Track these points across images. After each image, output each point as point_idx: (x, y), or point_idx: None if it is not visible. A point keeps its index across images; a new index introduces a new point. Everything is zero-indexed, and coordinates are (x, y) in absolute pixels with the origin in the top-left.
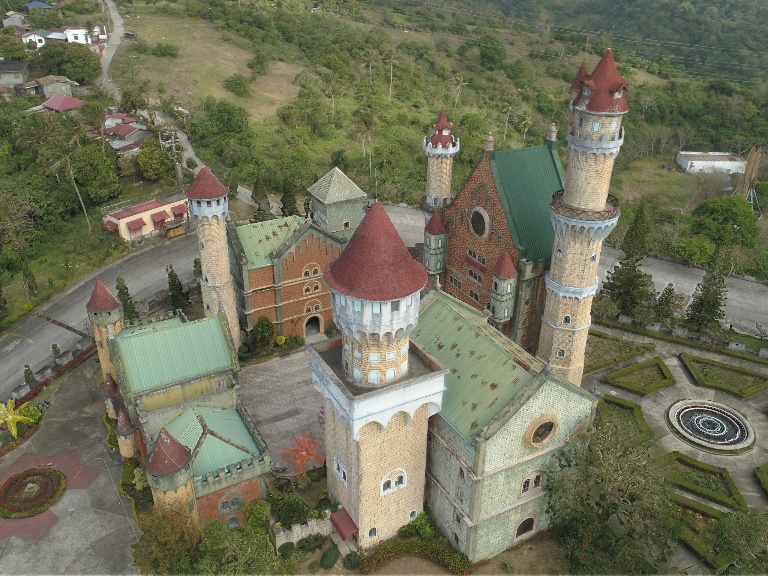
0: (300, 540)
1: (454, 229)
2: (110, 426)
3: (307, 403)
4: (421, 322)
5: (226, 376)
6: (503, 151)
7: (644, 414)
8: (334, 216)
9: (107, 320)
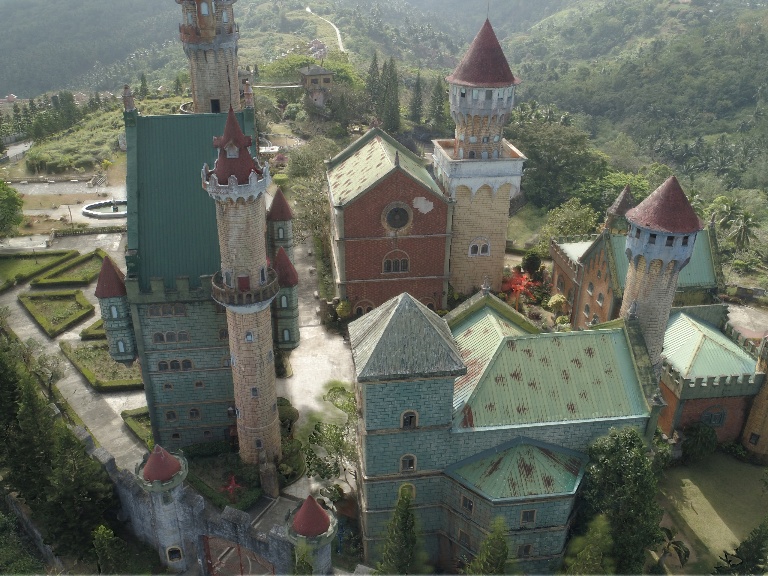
0: None
1: None
2: None
3: None
4: None
5: None
6: (224, 113)
7: None
8: None
9: None
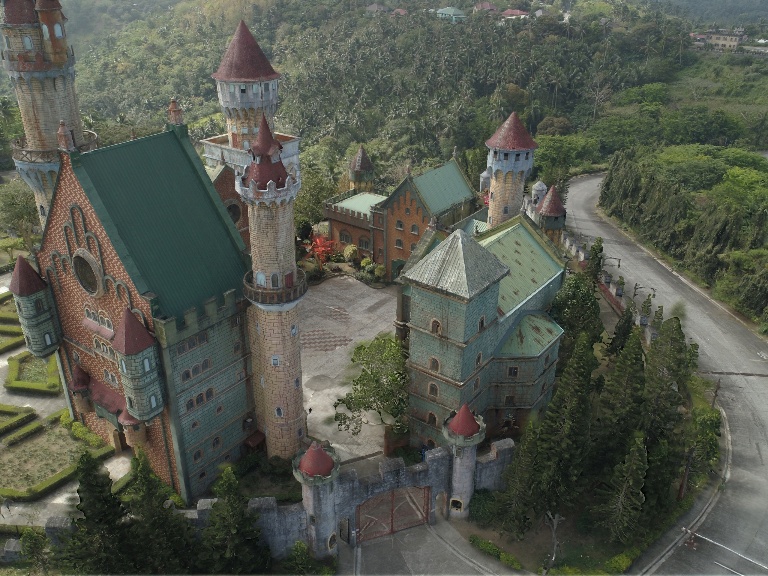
0: None
1: None
2: None
3: (367, 318)
4: None
5: None
6: (155, 135)
7: (2, 389)
8: None
9: None
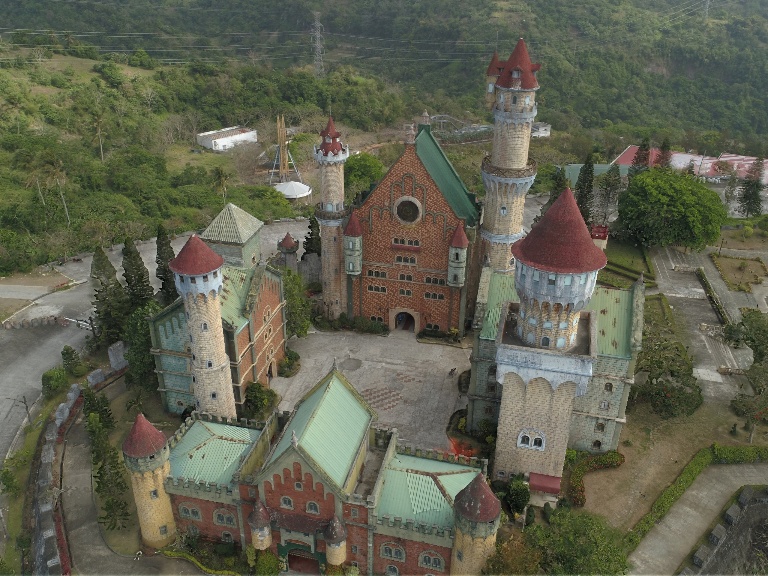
0: (527, 518)
1: (371, 226)
2: (229, 571)
3: None
4: (493, 297)
5: (369, 430)
6: None
7: None
8: (246, 254)
9: (164, 458)
